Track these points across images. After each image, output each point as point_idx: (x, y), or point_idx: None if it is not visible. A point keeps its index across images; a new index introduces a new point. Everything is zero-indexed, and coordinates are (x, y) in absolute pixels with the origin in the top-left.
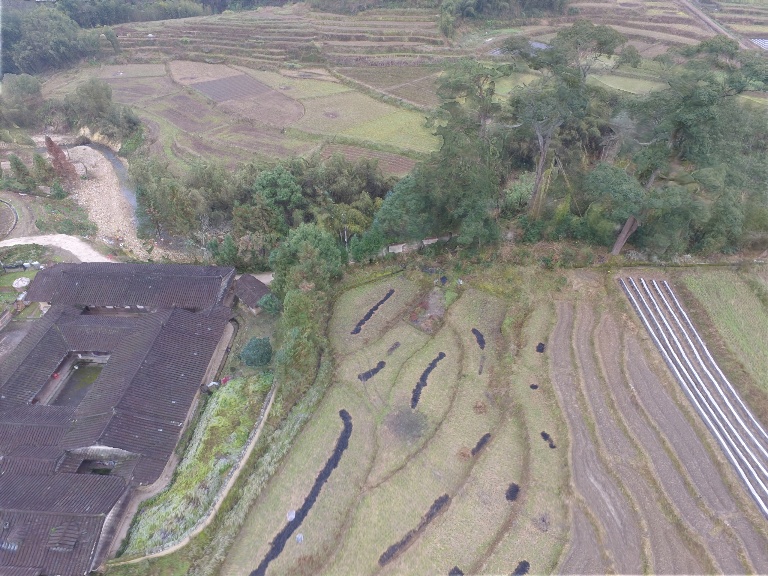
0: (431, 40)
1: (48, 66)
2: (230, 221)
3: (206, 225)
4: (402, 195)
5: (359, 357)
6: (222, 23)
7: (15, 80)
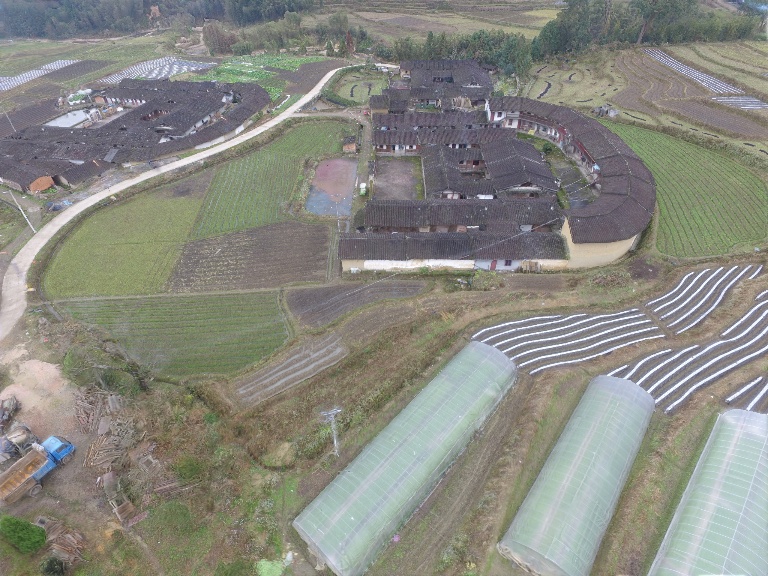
0: None
1: (276, 17)
2: (466, 50)
3: None
4: (550, 27)
5: (544, 74)
6: None
7: (290, 15)
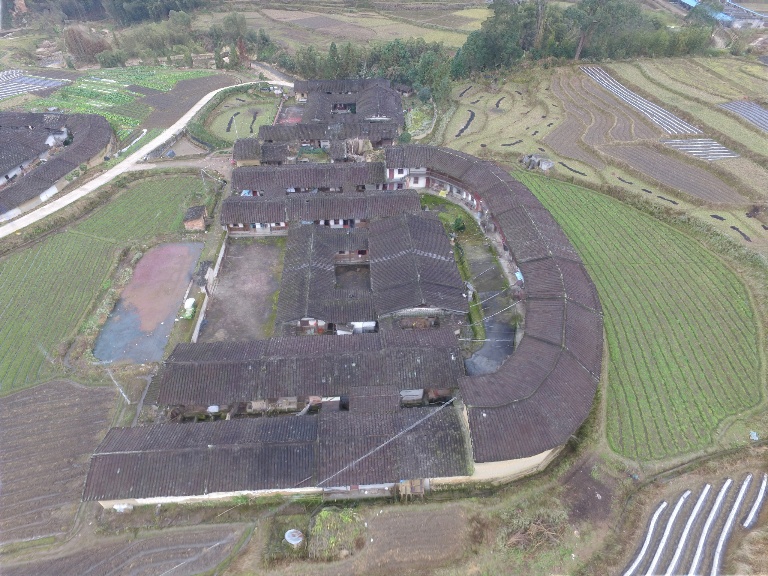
0: None
1: None
2: (377, 64)
3: (365, 66)
4: (474, 39)
5: (468, 99)
6: None
7: (177, 15)
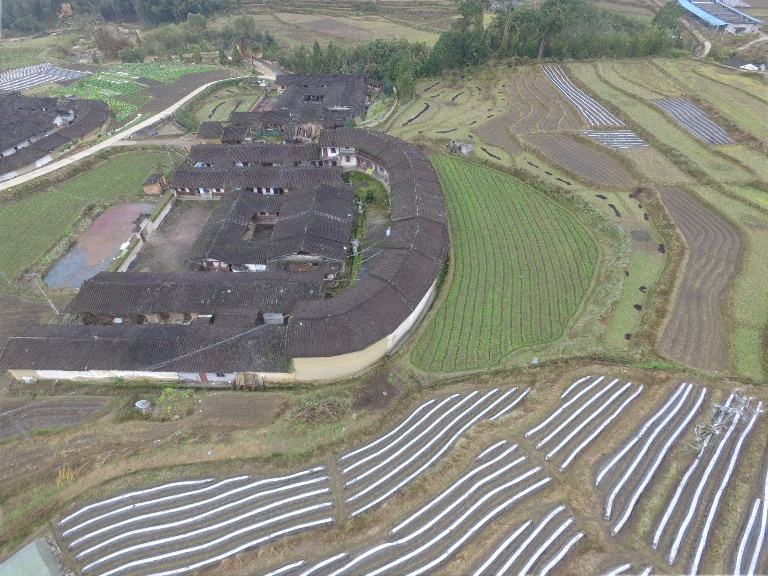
0: None
1: None
2: (357, 62)
3: None
4: (444, 39)
5: (429, 93)
6: None
7: (194, 17)
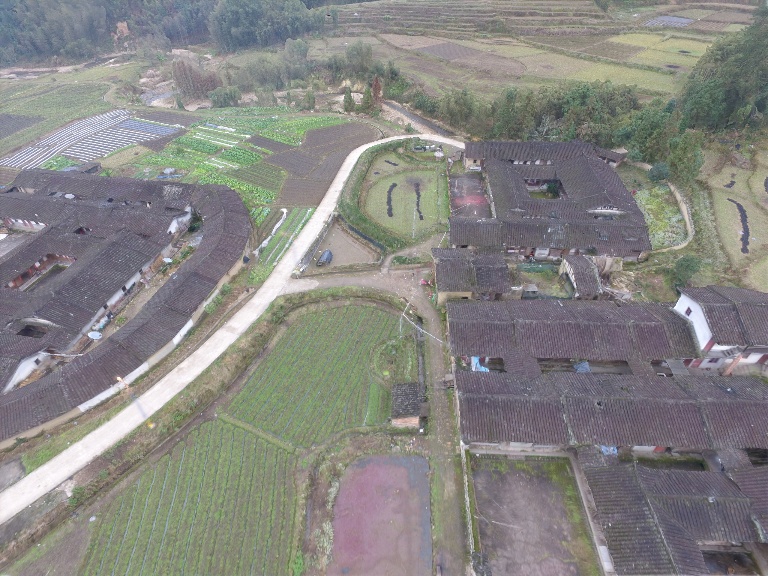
0: (594, 15)
1: (276, 40)
2: (563, 118)
3: None
4: (710, 90)
5: (716, 179)
6: (414, 4)
7: (293, 44)
